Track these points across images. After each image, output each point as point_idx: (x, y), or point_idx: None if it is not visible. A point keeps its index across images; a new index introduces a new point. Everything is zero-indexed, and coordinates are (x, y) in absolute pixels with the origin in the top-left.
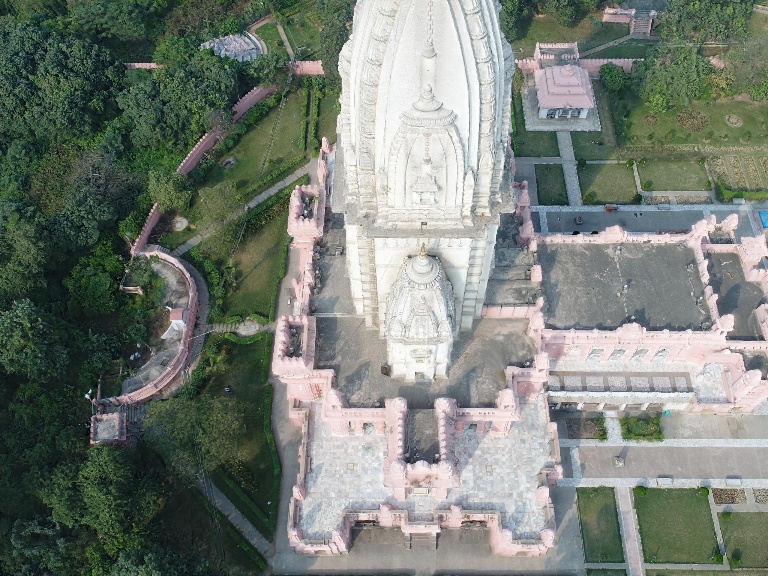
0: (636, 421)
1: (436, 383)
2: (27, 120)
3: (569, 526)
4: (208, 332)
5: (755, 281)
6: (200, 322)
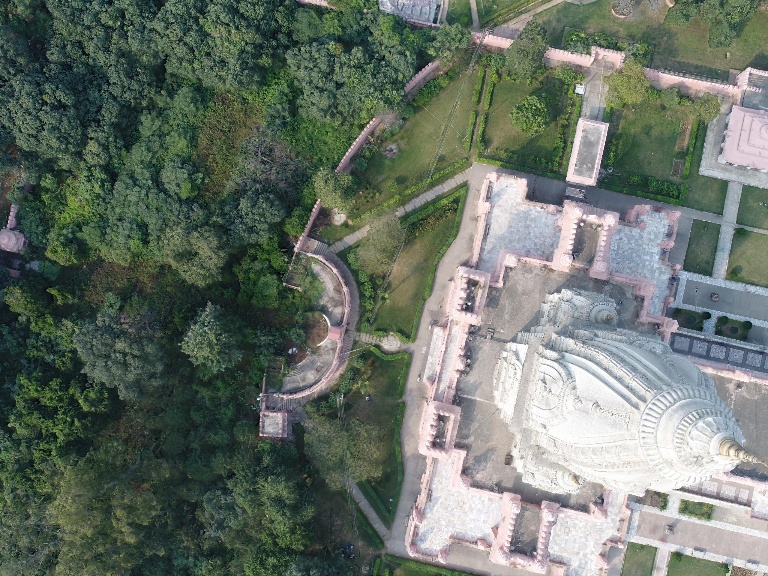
0: None
1: None
2: (196, 72)
3: (613, 568)
4: (358, 348)
5: None
6: (350, 328)
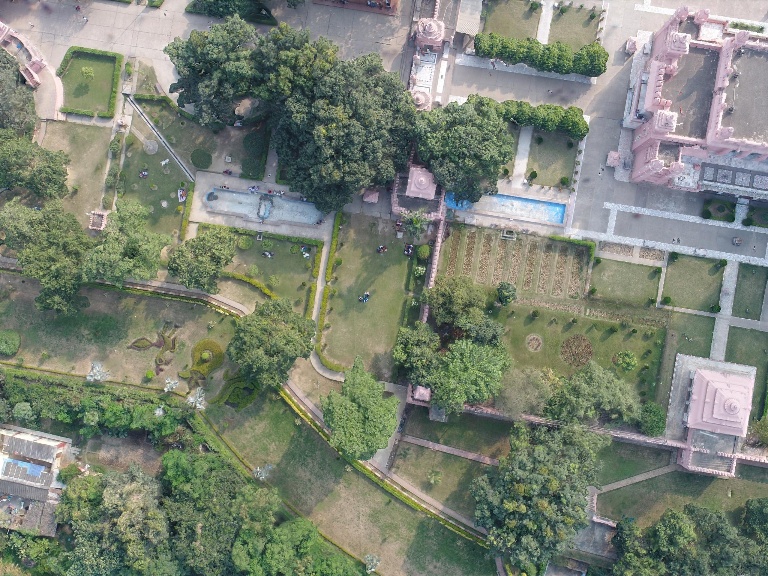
0: None
1: None
2: None
3: None
4: None
5: None
6: None
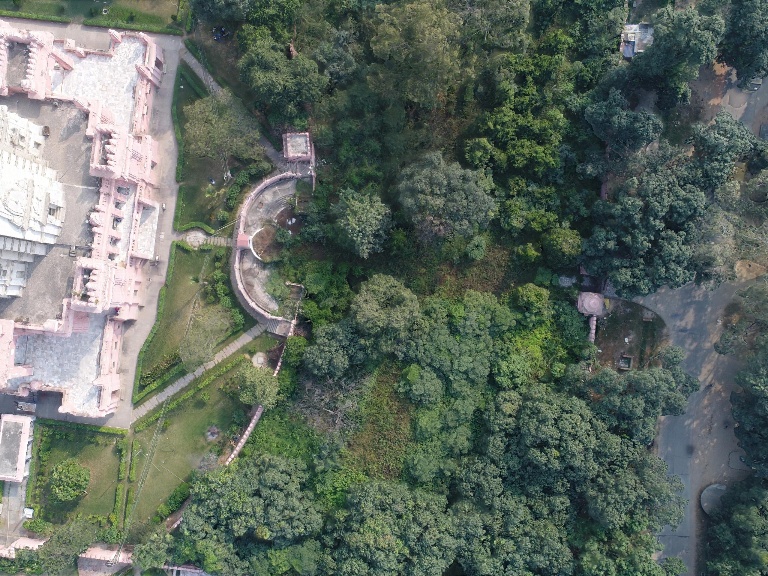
0: None
1: None
2: None
3: None
4: None
5: None
6: None
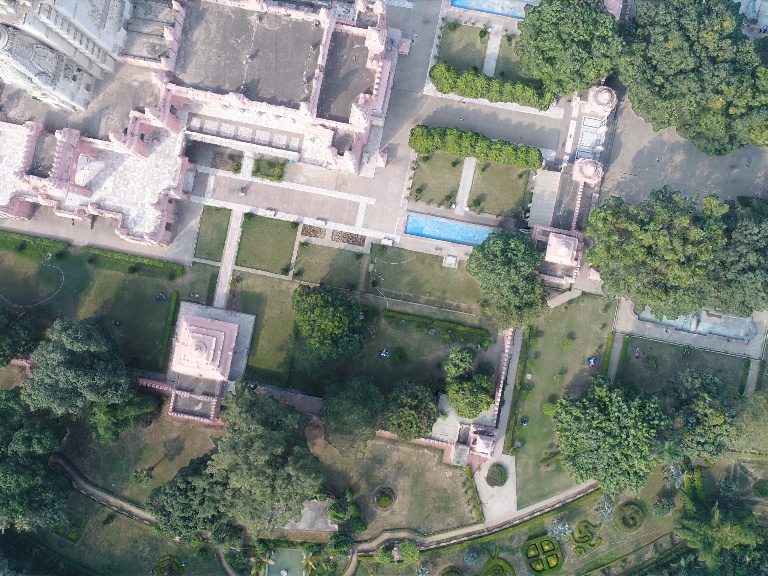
0: (267, 163)
1: (76, 113)
2: None
3: (190, 231)
4: None
5: (373, 68)
6: None
